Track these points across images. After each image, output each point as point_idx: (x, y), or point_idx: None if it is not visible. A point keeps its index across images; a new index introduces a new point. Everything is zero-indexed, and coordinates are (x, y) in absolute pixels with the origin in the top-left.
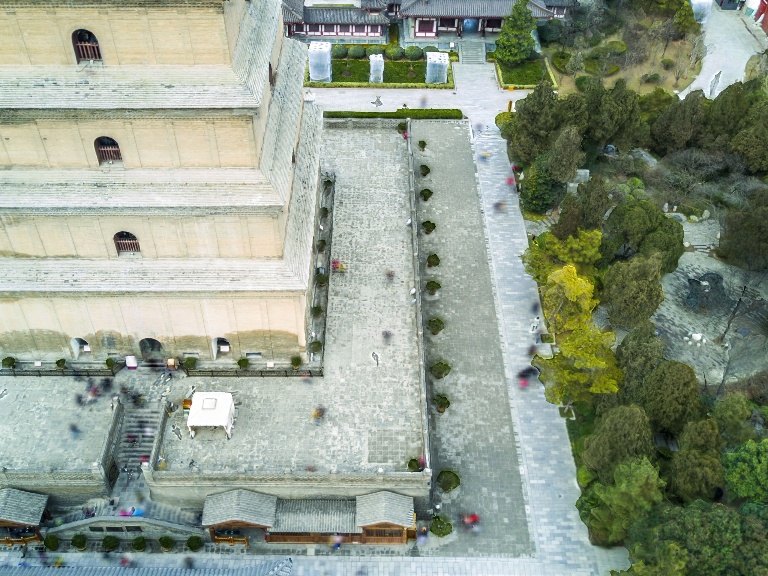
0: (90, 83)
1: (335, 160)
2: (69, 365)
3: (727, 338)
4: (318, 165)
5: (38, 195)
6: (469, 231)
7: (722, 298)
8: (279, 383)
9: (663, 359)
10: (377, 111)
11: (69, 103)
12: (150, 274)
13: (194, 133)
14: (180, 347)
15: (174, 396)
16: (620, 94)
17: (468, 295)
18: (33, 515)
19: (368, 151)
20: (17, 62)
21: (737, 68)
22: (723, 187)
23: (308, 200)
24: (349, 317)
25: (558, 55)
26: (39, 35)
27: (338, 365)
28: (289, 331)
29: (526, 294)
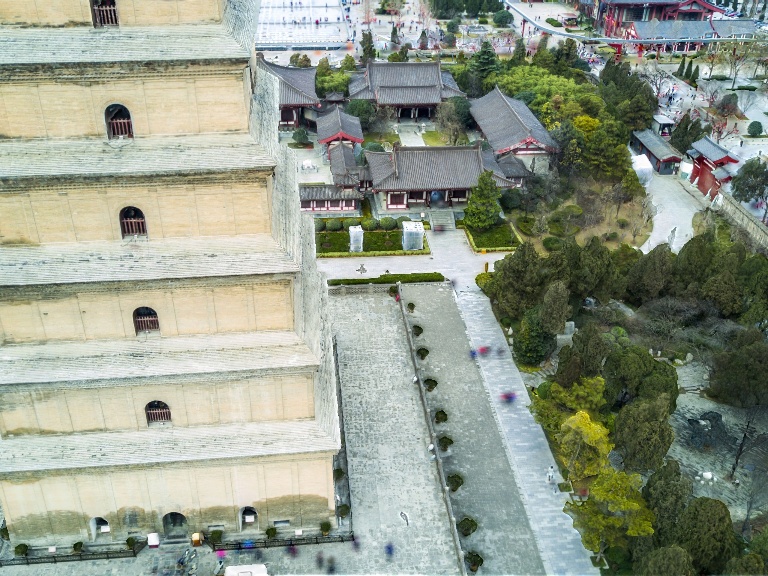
0: (135, 256)
1: (333, 325)
2: (86, 548)
3: (736, 475)
4: (330, 328)
5: (73, 368)
6: (469, 386)
7: (724, 436)
8: (310, 551)
9: (693, 496)
10: (361, 278)
11: (114, 276)
12: (181, 443)
13: (233, 299)
14: (205, 520)
15: (202, 573)
16: (597, 250)
17: (480, 449)
18: None
19: (364, 315)
20: (63, 240)
21: (685, 224)
22: (703, 330)
23: (328, 361)
24: (371, 478)
25: (522, 220)
26: (88, 213)
27: (368, 528)
28: (319, 494)
29: (536, 444)
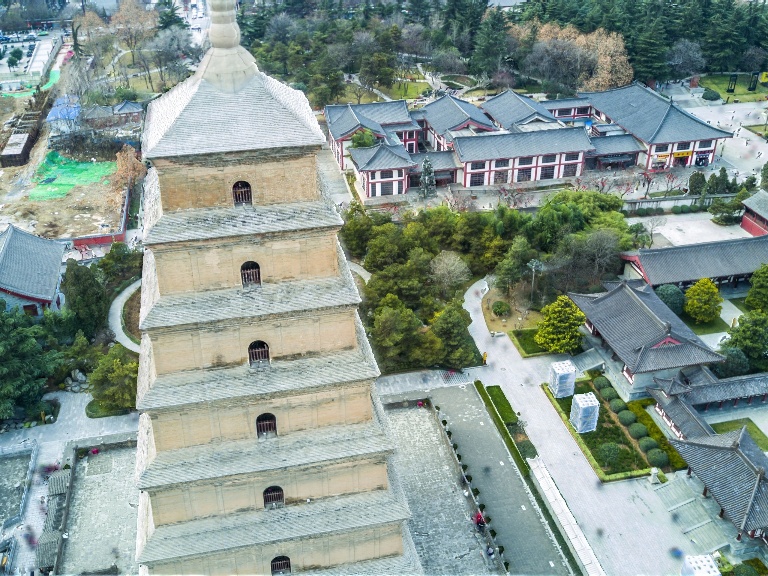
0: None
1: None
2: None
3: None
4: None
5: None
6: None
7: None
8: None
9: None
10: None
11: None
12: None
13: None
14: None
15: None
16: None
17: None
18: (41, 562)
19: None
20: None
21: None
22: None
23: None
24: None
25: None
26: None
27: None
28: None
29: None
